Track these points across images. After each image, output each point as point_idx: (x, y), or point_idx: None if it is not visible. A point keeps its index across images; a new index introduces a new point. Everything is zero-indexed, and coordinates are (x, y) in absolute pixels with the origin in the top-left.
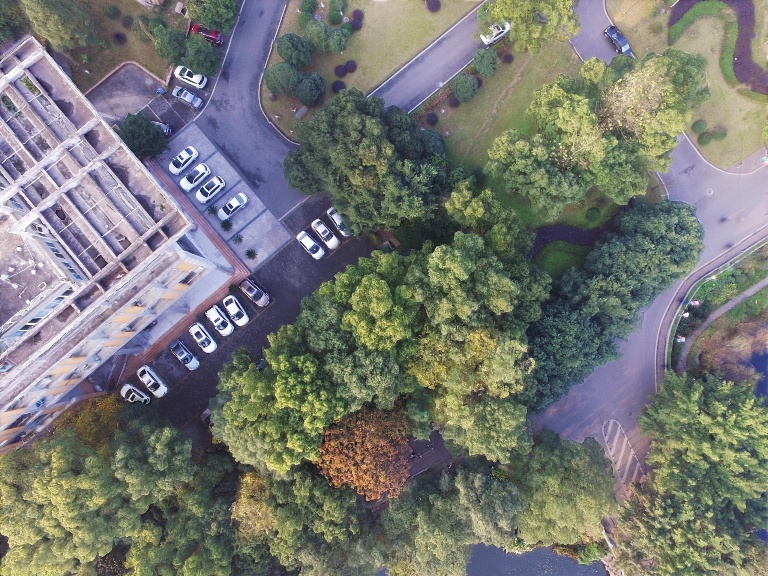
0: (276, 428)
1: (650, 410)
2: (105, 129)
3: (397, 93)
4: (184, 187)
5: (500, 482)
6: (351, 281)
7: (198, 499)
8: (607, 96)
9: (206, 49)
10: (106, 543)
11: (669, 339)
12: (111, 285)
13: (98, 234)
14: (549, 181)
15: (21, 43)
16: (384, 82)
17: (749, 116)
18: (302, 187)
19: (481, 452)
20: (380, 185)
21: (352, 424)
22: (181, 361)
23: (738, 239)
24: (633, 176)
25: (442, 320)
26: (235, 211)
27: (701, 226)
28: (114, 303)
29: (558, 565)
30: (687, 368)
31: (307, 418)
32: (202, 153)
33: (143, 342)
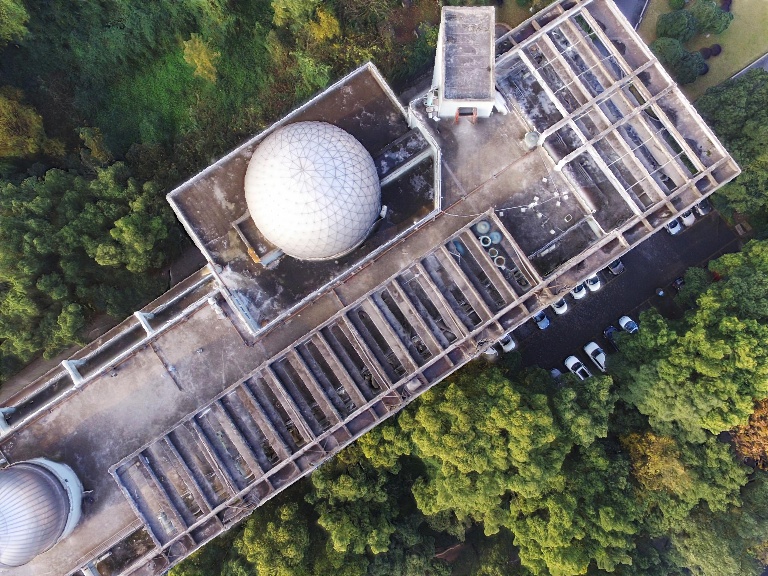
0: None
1: None
2: (657, 72)
3: None
4: None
5: None
6: None
7: (600, 452)
8: None
9: None
10: None
11: None
12: (656, 223)
13: None
14: None
15: None
16: (743, 69)
17: None
18: None
19: None
20: None
21: None
22: (534, 319)
23: None
24: None
25: None
26: None
27: None
28: None
29: None
30: None
31: (767, 381)
32: None
33: None
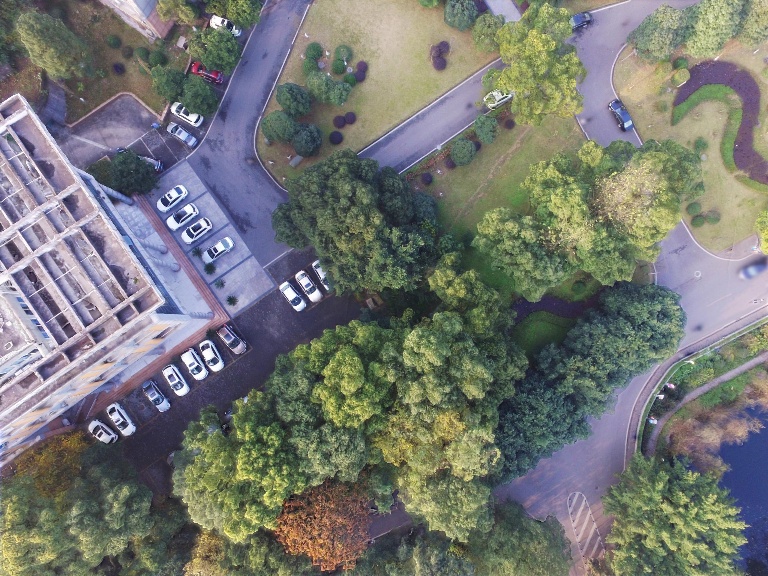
0: (235, 499)
1: (615, 492)
2: (85, 195)
3: (394, 149)
4: (170, 226)
5: (457, 560)
6: (326, 350)
7: (154, 553)
8: (601, 185)
9: (203, 92)
10: None
11: (642, 418)
12: (77, 355)
13: (68, 302)
14: (535, 265)
15: (16, 67)
16: (382, 136)
17: (744, 203)
18: (288, 240)
19: (441, 529)
20: (366, 249)
21: (313, 498)
22: (152, 402)
23: (721, 324)
24: (620, 263)
25: (412, 402)
26: (220, 255)
27: (684, 314)
28: (82, 362)
29: None
30: (657, 447)
31: (267, 492)
32: (192, 192)
33: (116, 379)
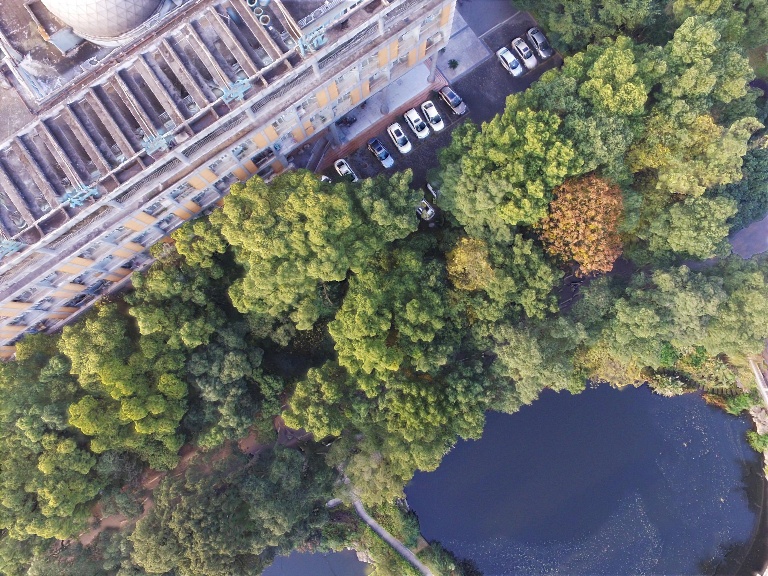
0: None
1: None
2: None
3: None
4: None
5: (704, 275)
6: (584, 61)
7: (415, 256)
8: None
9: None
10: (344, 269)
11: None
12: None
13: None
14: None
15: None
16: None
17: None
18: None
19: (687, 244)
20: None
21: (586, 183)
22: (378, 157)
23: None
24: None
25: (680, 94)
26: None
27: None
28: (386, 31)
29: (706, 412)
30: None
31: (554, 162)
32: None
33: (341, 137)
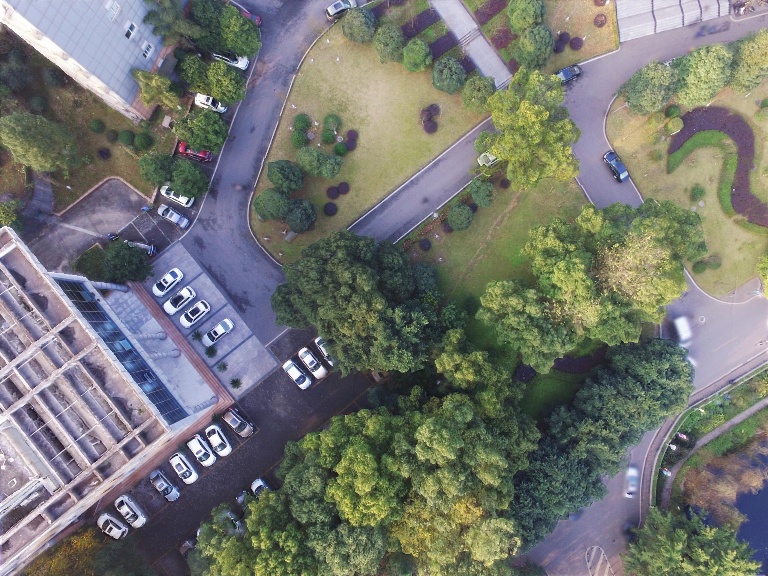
0: None
1: (634, 550)
2: (81, 326)
3: (390, 216)
4: (168, 311)
5: None
6: (336, 443)
7: None
8: (603, 254)
9: (193, 177)
10: None
11: (655, 467)
12: (84, 492)
13: (71, 439)
14: (541, 339)
15: None
16: (377, 204)
17: (744, 246)
18: None
19: None
20: (369, 330)
21: None
22: (161, 493)
23: (728, 368)
24: (626, 327)
25: (428, 495)
26: (220, 337)
27: (692, 366)
28: None
29: None
30: (672, 495)
31: None
32: (187, 274)
33: None
